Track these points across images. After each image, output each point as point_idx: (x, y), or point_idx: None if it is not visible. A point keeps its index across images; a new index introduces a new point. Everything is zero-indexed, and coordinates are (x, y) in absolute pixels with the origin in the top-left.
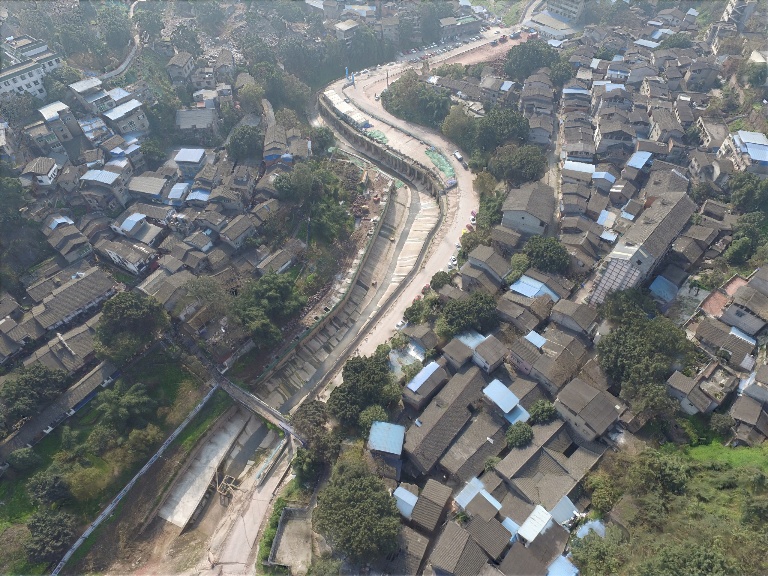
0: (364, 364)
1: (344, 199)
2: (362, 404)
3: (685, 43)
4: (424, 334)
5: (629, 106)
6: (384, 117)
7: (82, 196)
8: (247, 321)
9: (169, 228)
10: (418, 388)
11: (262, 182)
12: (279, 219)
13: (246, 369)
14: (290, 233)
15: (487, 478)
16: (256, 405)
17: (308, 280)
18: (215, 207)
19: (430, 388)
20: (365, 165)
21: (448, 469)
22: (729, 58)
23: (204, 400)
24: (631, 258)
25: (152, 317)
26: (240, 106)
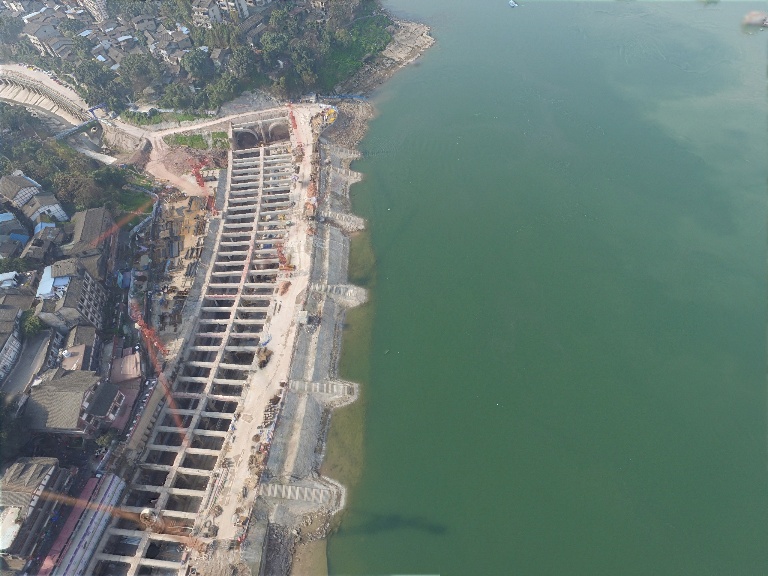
0: None
1: None
2: None
3: None
4: (81, 61)
5: None
6: None
7: None
8: None
9: None
10: (105, 59)
11: None
12: None
13: None
14: None
15: None
16: None
17: None
18: None
19: None
20: None
21: None
22: None
23: None
24: None
25: None
26: None
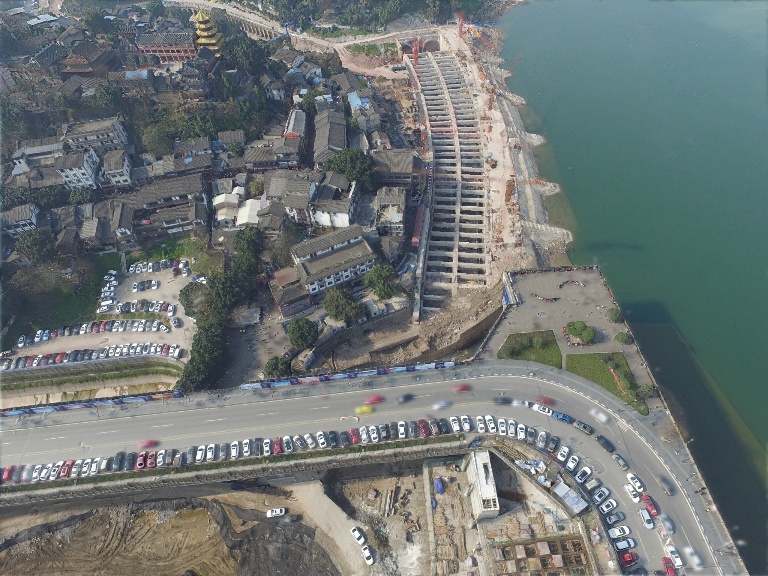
0: None
1: None
2: None
3: None
4: None
5: None
6: None
7: None
8: None
9: None
10: None
11: None
12: None
13: None
14: None
15: None
16: None
17: None
18: (157, 20)
19: None
20: None
21: None
22: None
23: None
24: None
25: None
26: None
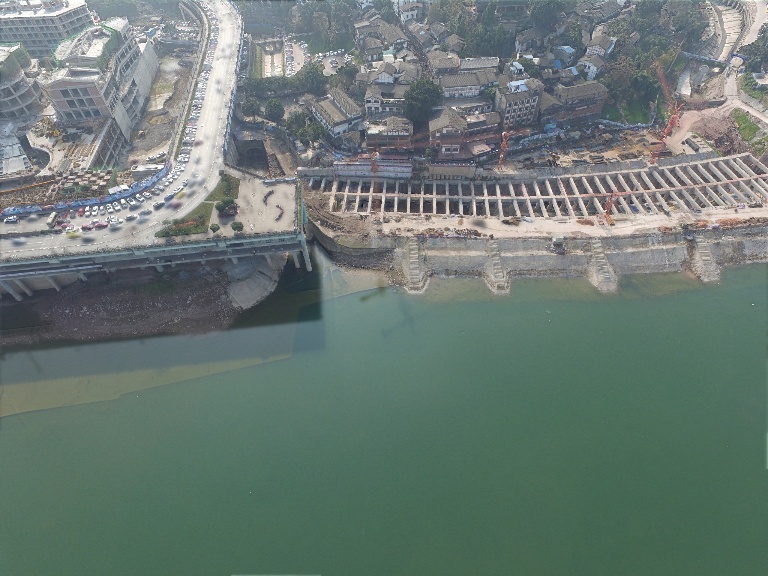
0: None
1: None
2: None
3: None
4: None
5: None
6: None
7: None
8: None
9: None
10: None
11: None
12: None
13: None
14: None
15: None
16: None
17: None
18: None
19: None
20: None
21: None
22: None
23: (676, 56)
24: None
25: None
26: None
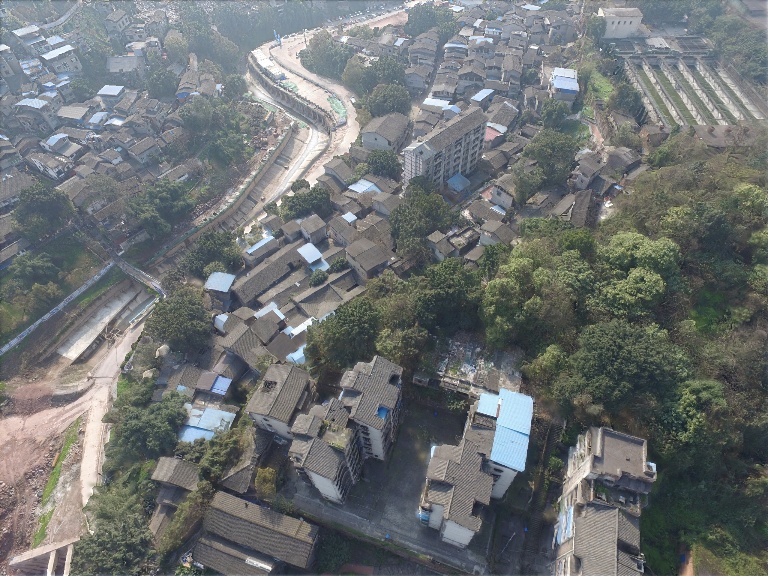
0: (214, 234)
1: (247, 133)
2: (207, 261)
3: (560, 6)
4: (272, 219)
5: (493, 56)
6: (300, 71)
7: (18, 120)
8: (139, 213)
9: (88, 147)
10: (253, 251)
11: (171, 114)
12: (183, 143)
13: (140, 253)
14: (192, 155)
15: (286, 306)
16: (142, 277)
17: (201, 191)
18: (126, 130)
19: (263, 252)
20: (277, 111)
21: (261, 302)
22: (583, 15)
23: (101, 273)
24: (414, 149)
25: (59, 204)
26: (167, 57)
